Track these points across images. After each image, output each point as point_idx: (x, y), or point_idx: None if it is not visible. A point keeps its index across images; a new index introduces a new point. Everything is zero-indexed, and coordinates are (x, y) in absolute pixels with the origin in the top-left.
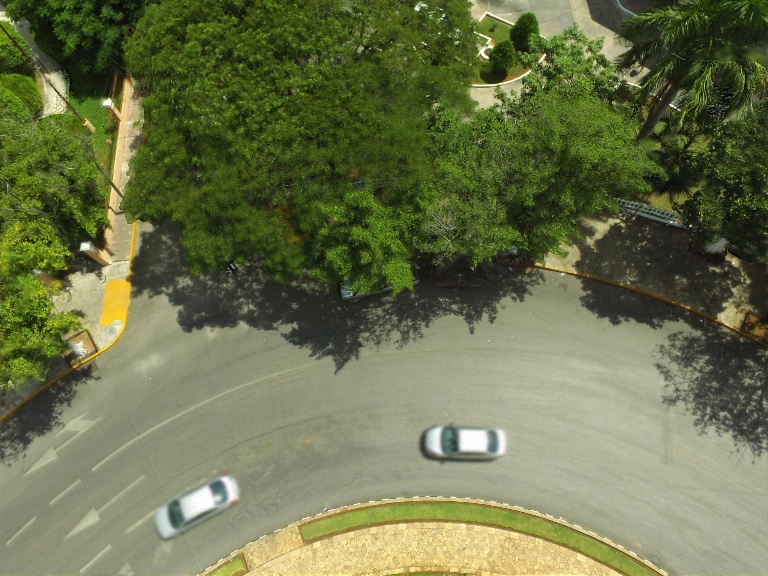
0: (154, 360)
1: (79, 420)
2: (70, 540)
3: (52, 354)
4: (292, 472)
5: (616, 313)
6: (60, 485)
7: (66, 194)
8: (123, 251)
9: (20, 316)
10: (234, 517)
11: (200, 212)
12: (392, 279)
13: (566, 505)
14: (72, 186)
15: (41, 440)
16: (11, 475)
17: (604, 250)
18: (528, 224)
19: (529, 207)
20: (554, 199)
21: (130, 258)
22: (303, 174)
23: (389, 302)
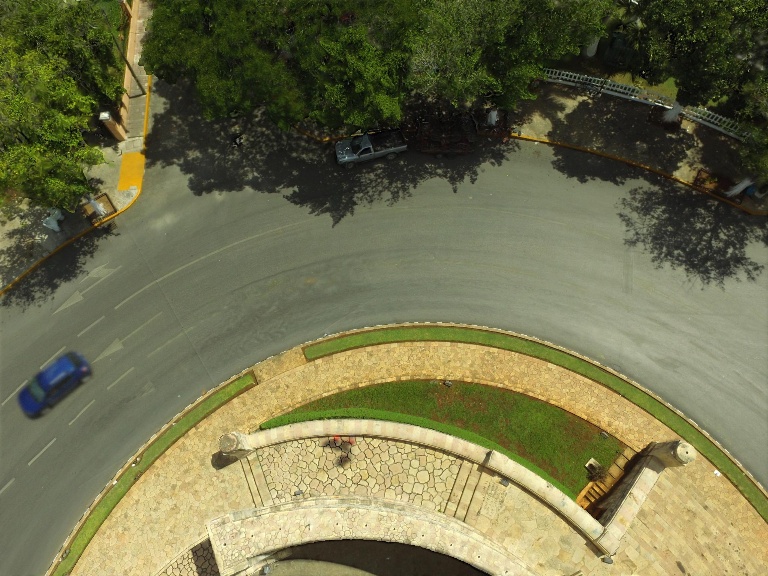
0: (168, 219)
1: (101, 269)
2: (97, 364)
3: (80, 191)
4: (295, 306)
5: (584, 173)
6: (86, 321)
7: (90, 53)
8: (137, 129)
9: (56, 136)
10: (244, 343)
11: (212, 56)
12: (382, 106)
13: (539, 327)
14: (95, 45)
15: (67, 285)
16: (41, 314)
17: (573, 122)
18: (502, 72)
19: (502, 51)
20: (523, 39)
21: (144, 134)
22: (304, 15)
23: (380, 168)
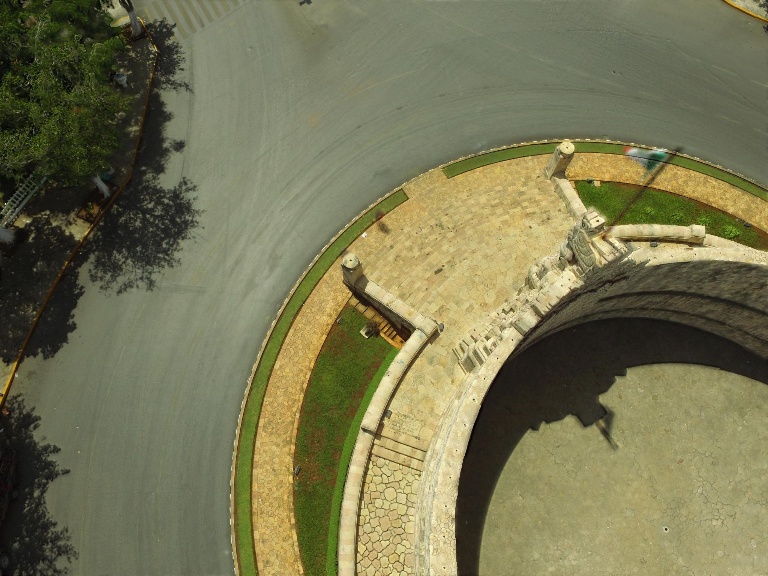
0: None
1: None
2: None
3: None
4: None
5: (64, 326)
6: None
7: None
8: None
9: None
10: None
11: None
12: None
13: (237, 376)
14: None
15: None
16: None
17: None
18: None
19: None
20: None
21: None
22: None
23: (20, 574)
